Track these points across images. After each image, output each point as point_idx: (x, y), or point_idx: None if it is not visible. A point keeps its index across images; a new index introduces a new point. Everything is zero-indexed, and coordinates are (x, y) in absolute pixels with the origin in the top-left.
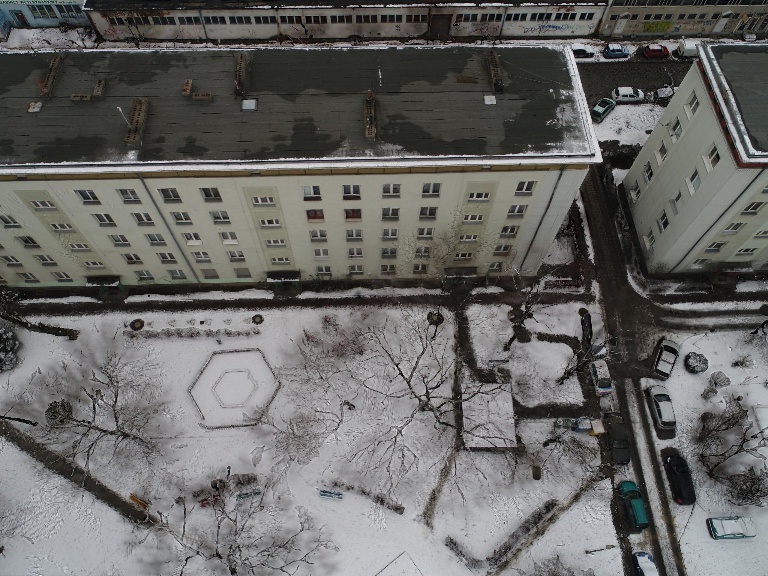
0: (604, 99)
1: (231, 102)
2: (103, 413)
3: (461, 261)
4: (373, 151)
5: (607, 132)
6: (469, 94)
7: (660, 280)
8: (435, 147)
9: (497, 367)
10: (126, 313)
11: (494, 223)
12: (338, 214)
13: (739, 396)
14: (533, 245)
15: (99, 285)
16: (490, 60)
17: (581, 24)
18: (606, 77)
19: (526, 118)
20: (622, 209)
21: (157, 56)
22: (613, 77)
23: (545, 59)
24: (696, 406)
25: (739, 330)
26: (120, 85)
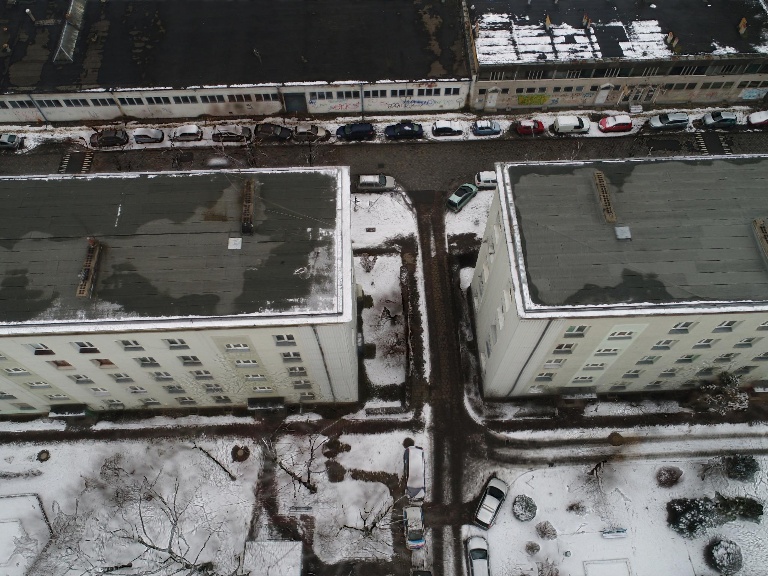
0: (464, 185)
1: None
2: None
3: (262, 393)
4: (86, 312)
5: (464, 223)
6: (213, 236)
7: (499, 403)
8: (158, 306)
9: (299, 514)
10: None
11: (272, 366)
12: (86, 363)
13: (567, 551)
14: (333, 380)
15: None
16: (244, 193)
17: (448, 99)
18: (472, 158)
19: (272, 266)
20: (468, 316)
21: None
22: (480, 158)
23: (313, 188)
24: (519, 561)
25: (581, 464)
26: None
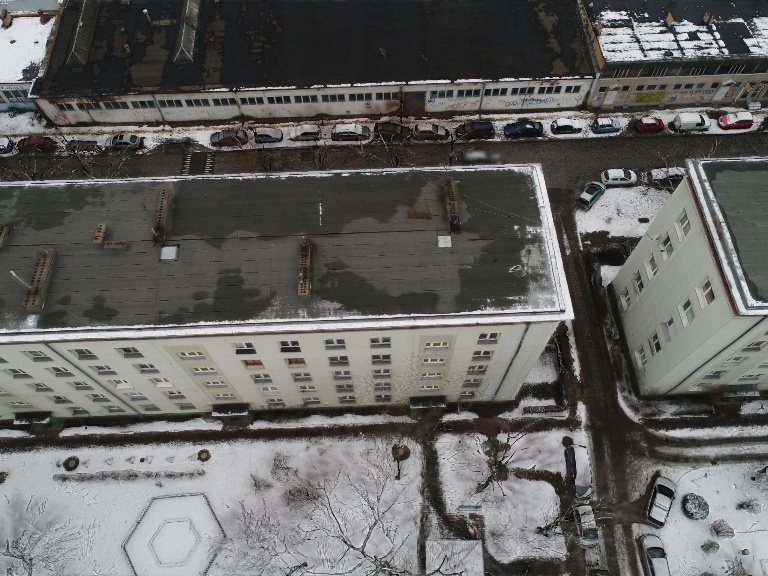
0: (592, 183)
1: (149, 250)
2: (27, 574)
3: (427, 392)
4: (307, 311)
5: (596, 221)
6: (421, 234)
7: (654, 401)
8: (379, 304)
9: (469, 513)
10: (60, 449)
11: (458, 364)
12: (279, 362)
13: (745, 550)
14: (506, 379)
15: (28, 422)
16: (446, 191)
17: (567, 97)
18: (595, 156)
19: (486, 264)
20: (612, 314)
21: (71, 191)
22: (603, 155)
23: (510, 185)
24: (695, 560)
25: (744, 462)
26: (26, 230)
